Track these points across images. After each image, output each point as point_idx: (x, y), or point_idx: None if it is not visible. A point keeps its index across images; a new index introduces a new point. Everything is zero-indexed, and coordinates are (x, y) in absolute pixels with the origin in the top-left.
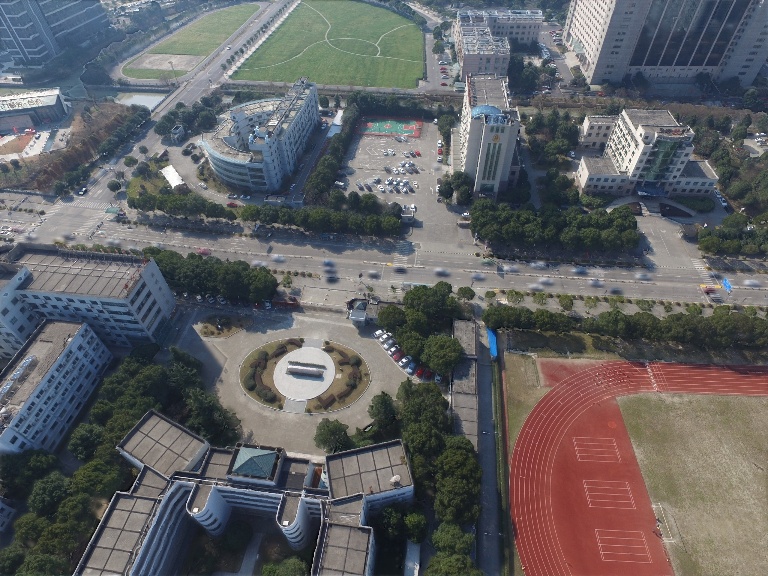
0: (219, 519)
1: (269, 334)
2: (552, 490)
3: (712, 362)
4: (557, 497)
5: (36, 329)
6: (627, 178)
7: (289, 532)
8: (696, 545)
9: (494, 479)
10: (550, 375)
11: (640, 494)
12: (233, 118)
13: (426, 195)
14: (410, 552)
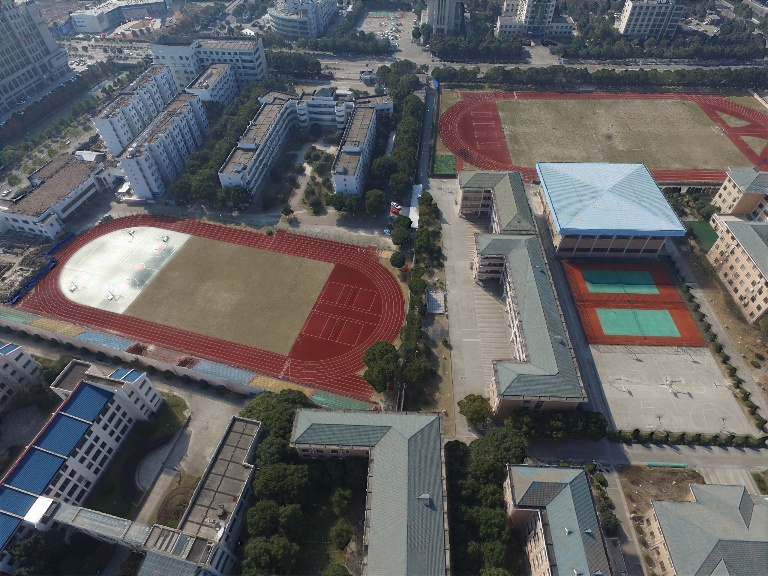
0: (307, 122)
1: (319, 87)
2: (458, 123)
3: (548, 91)
4: (460, 125)
5: (208, 65)
6: (522, 25)
7: (340, 114)
8: (518, 133)
9: (431, 121)
10: (464, 95)
11: (498, 123)
12: (285, 1)
13: (405, 40)
14: (392, 133)
